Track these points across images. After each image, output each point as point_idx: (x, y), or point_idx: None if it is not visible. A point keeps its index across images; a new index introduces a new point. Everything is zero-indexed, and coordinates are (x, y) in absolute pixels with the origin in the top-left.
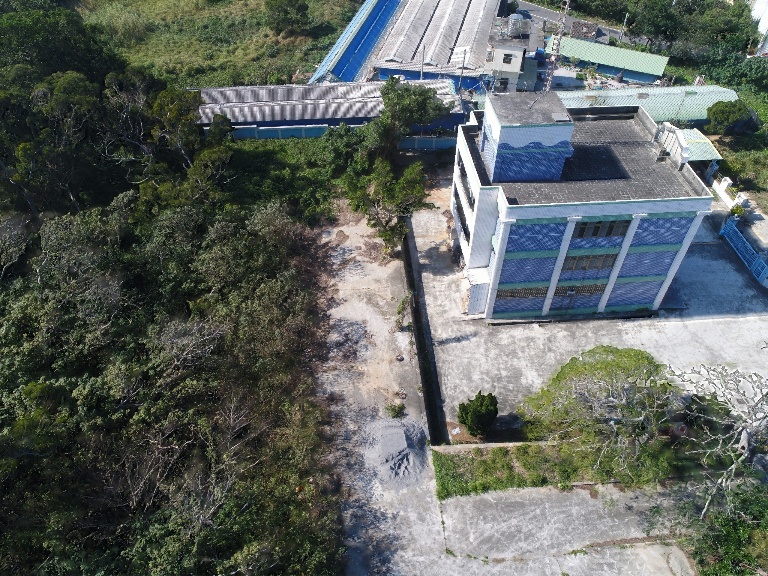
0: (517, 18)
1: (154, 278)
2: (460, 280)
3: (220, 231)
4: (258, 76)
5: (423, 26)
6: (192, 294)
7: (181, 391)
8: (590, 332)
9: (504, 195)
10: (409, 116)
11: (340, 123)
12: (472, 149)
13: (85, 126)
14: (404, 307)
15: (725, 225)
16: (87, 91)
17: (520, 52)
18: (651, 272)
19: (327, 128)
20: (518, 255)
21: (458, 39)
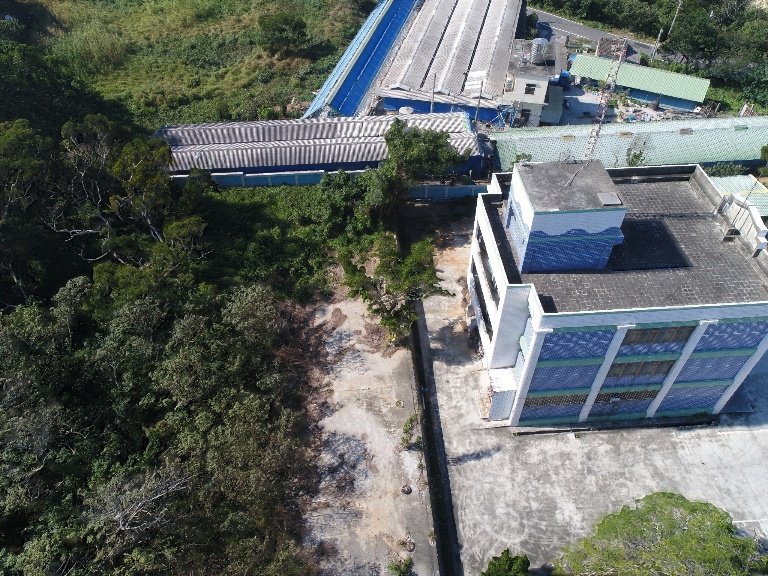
0: (541, 43)
1: (108, 388)
2: (479, 372)
3: (188, 329)
4: (247, 109)
5: (433, 46)
6: (153, 409)
7: (124, 574)
8: (638, 445)
9: (538, 298)
10: (418, 167)
11: (338, 170)
12: (495, 224)
13: (37, 186)
14: (412, 426)
15: None
16: (33, 151)
17: (545, 82)
18: (715, 376)
19: (324, 174)
20: (553, 363)
21: (473, 61)
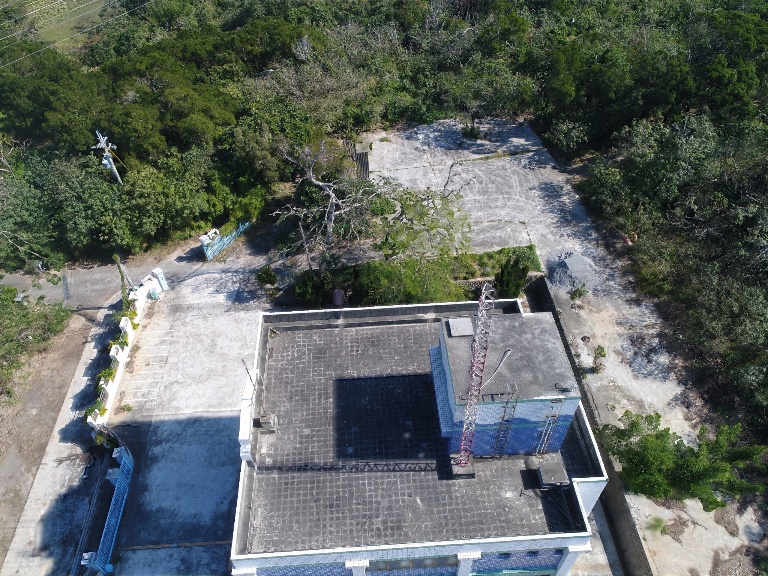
0: None
1: None
2: None
3: None
4: None
5: None
6: None
7: (761, 227)
8: None
9: None
10: None
11: None
12: (571, 451)
13: None
14: None
15: (101, 568)
16: None
17: None
18: None
19: None
20: None
21: None
